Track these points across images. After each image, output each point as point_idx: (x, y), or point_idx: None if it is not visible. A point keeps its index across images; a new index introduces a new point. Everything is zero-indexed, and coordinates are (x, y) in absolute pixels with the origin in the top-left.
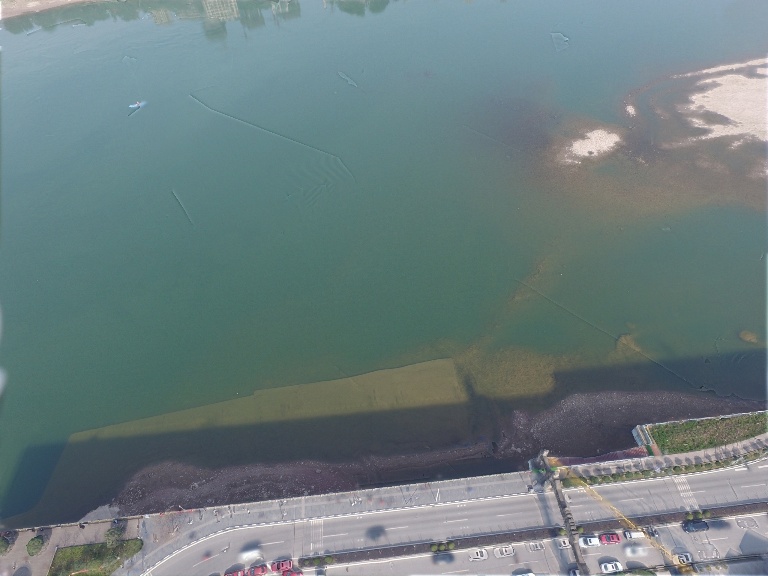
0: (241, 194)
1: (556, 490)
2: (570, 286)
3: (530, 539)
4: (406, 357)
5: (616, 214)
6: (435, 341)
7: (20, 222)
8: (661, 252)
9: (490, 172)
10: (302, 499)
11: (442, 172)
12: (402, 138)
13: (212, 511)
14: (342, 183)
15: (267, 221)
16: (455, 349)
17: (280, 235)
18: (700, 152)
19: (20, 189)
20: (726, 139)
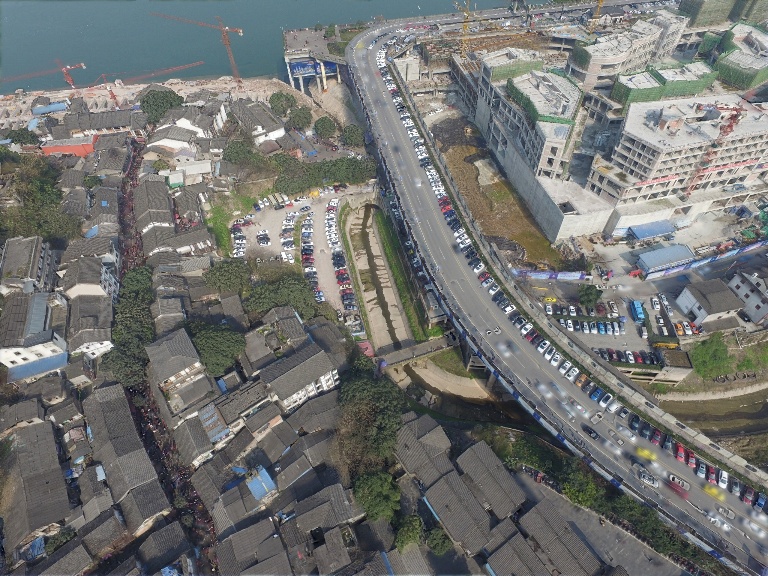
0: None
1: None
2: None
3: None
4: None
5: None
6: None
7: (219, 5)
8: None
9: None
10: (424, 18)
11: None
12: None
13: (392, 21)
14: None
15: None
16: None
17: (367, 3)
18: None
19: None
20: None
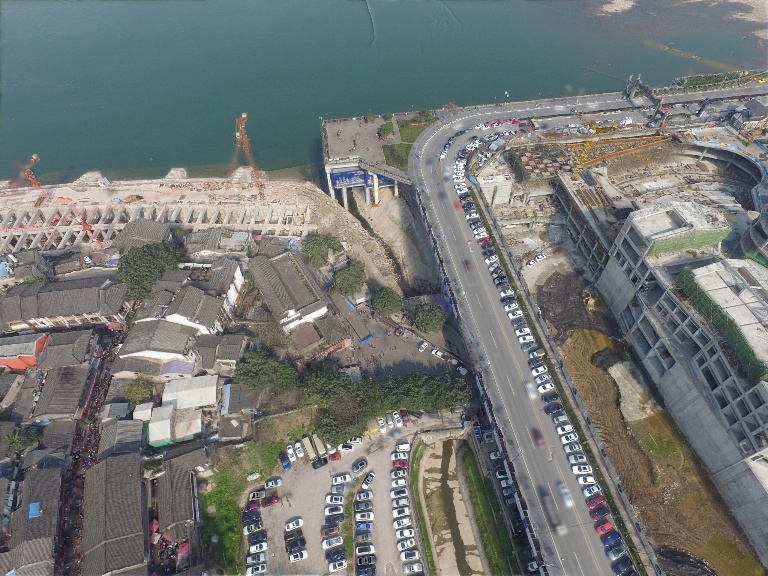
0: (403, 18)
1: (639, 84)
2: (616, 69)
3: (627, 109)
4: (525, 99)
5: (639, 38)
6: (540, 93)
7: (239, 53)
8: (670, 54)
9: (550, 22)
10: (511, 104)
11: (514, 28)
12: (479, 13)
13: (467, 109)
14: (454, 26)
15: (417, 39)
16: (553, 95)
17: (420, 55)
18: (690, 8)
19: (225, 39)
20: (706, 2)
